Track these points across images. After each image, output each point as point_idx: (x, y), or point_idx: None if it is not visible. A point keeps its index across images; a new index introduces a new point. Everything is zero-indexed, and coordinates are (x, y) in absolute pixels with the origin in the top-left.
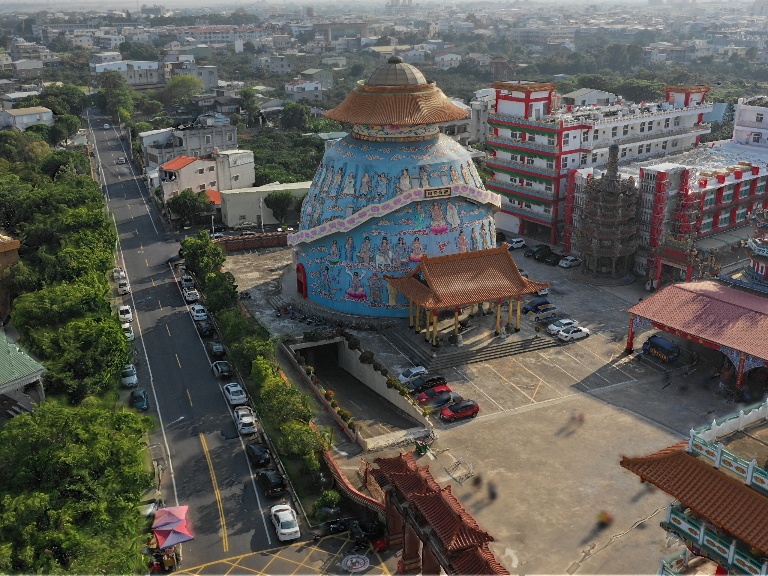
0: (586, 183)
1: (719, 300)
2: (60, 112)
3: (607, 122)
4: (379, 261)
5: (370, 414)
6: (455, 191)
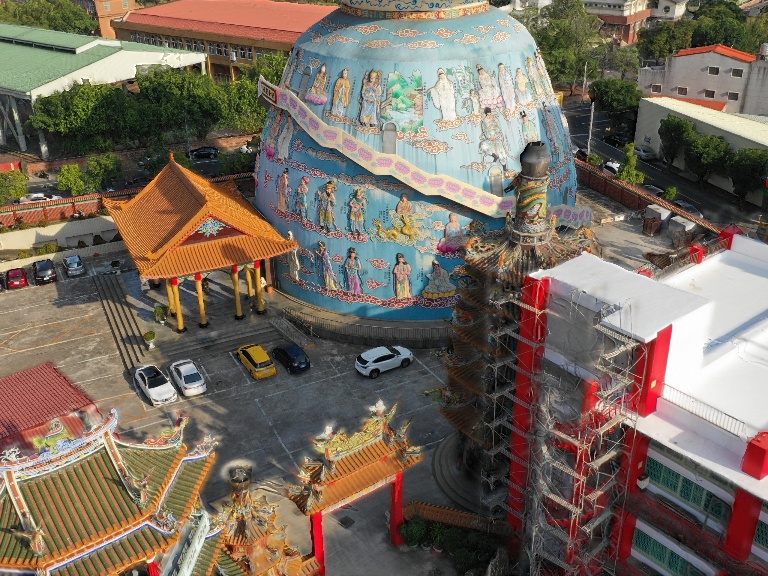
0: None
1: None
2: None
3: None
4: None
5: None
6: (283, 100)
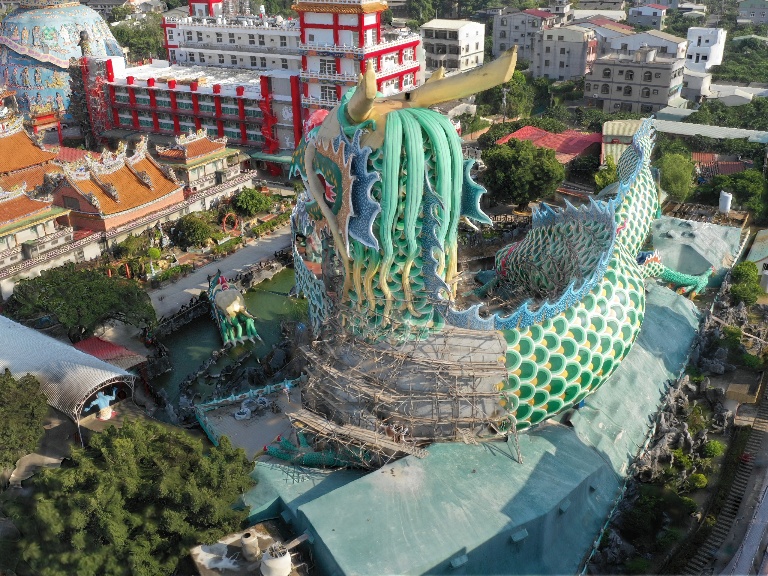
0: None
1: None
2: (415, 7)
3: (192, 25)
4: None
5: None
6: None
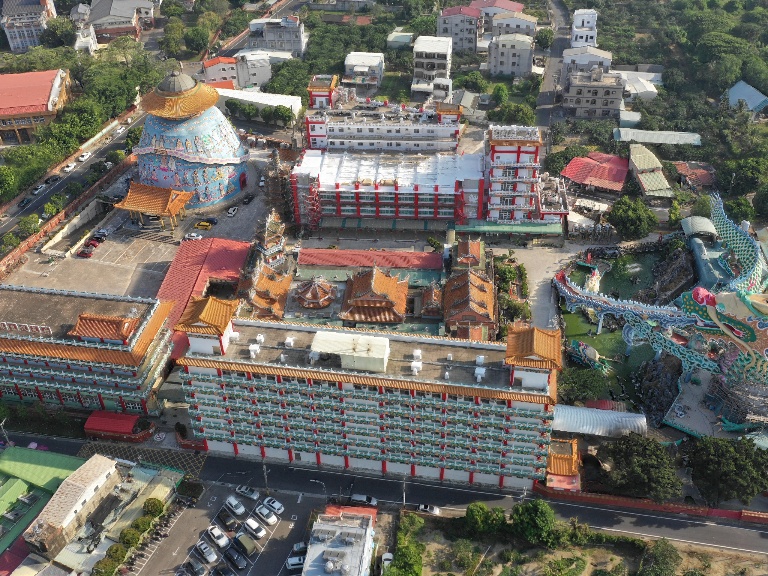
0: None
1: (207, 254)
2: None
3: (340, 124)
4: None
5: (75, 241)
6: (171, 153)
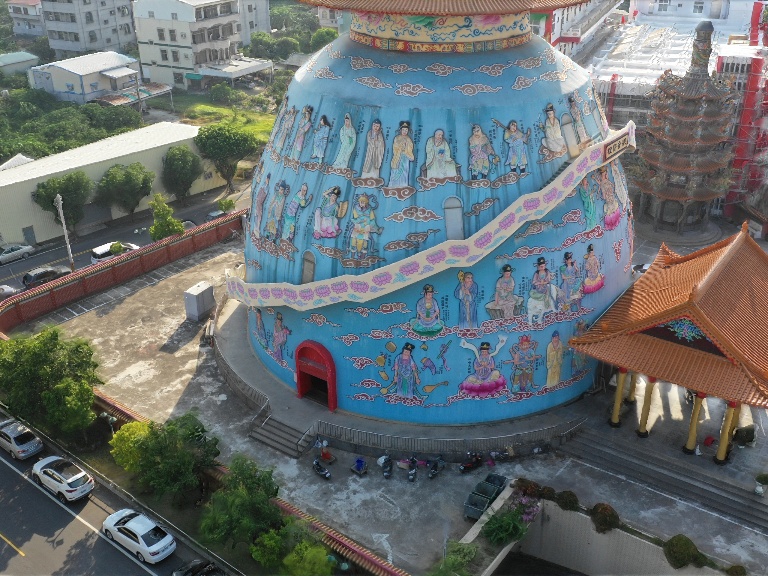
0: (609, 89)
1: None
2: None
3: None
4: (534, 310)
5: None
6: None
